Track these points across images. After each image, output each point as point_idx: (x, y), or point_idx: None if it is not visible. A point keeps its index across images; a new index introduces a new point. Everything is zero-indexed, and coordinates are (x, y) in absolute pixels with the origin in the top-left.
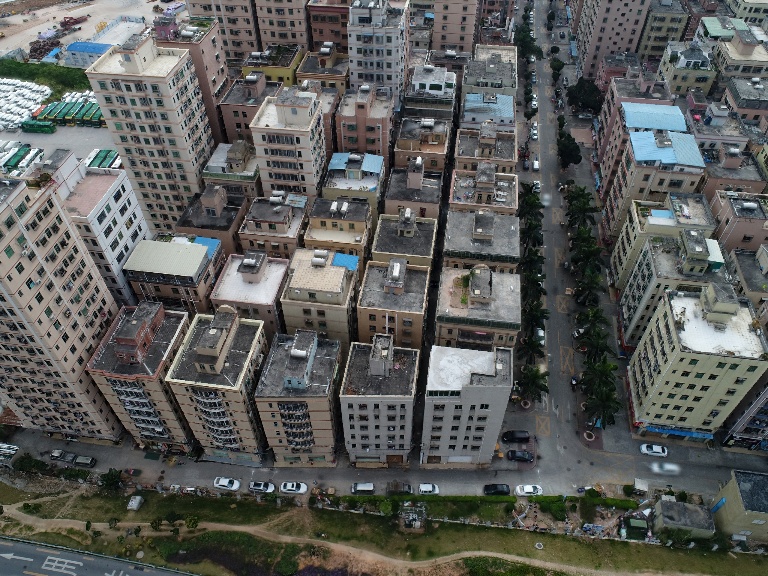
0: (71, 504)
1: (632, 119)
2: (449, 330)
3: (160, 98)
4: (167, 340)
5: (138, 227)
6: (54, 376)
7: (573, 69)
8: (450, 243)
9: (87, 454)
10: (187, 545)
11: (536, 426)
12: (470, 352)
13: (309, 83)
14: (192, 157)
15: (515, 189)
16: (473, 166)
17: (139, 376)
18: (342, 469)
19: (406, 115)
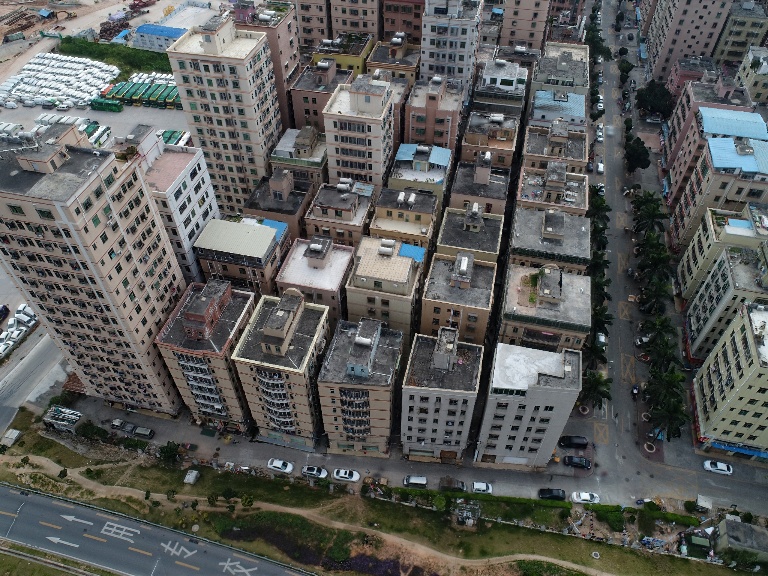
0: (130, 473)
1: (710, 124)
2: (514, 328)
3: (237, 80)
4: (233, 319)
5: (209, 206)
6: (124, 346)
7: (641, 72)
8: (518, 240)
9: (146, 426)
10: (241, 523)
11: (594, 433)
12: (537, 352)
13: (380, 72)
14: (261, 140)
15: (585, 190)
16: (541, 164)
17: (206, 352)
18: (395, 461)
19: (474, 109)
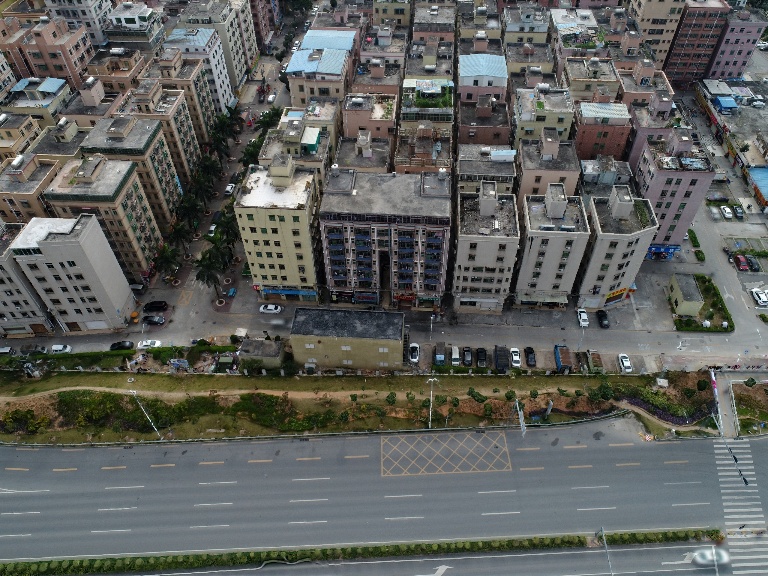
0: None
1: (307, 42)
2: (63, 209)
3: None
4: None
5: None
6: None
7: None
8: (87, 142)
9: None
10: None
11: (179, 298)
12: (63, 220)
13: (5, 19)
14: None
15: (176, 101)
16: None
17: None
18: None
19: None
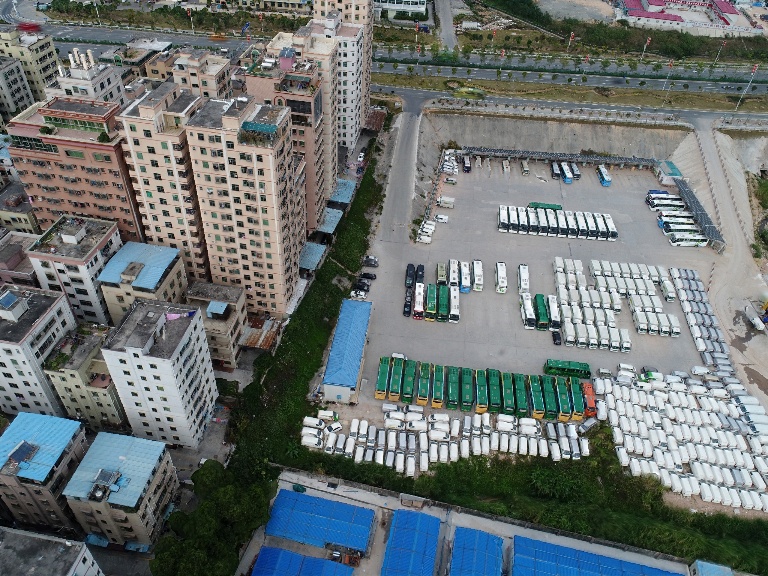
0: None
1: None
2: None
3: None
4: None
5: None
6: None
7: None
8: None
9: None
10: None
11: None
12: None
13: None
14: None
15: None
16: None
17: None
18: None
19: None
